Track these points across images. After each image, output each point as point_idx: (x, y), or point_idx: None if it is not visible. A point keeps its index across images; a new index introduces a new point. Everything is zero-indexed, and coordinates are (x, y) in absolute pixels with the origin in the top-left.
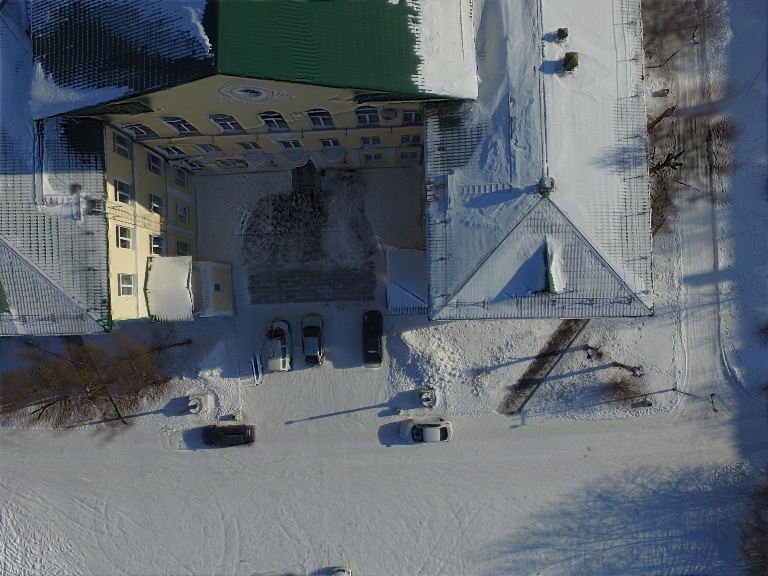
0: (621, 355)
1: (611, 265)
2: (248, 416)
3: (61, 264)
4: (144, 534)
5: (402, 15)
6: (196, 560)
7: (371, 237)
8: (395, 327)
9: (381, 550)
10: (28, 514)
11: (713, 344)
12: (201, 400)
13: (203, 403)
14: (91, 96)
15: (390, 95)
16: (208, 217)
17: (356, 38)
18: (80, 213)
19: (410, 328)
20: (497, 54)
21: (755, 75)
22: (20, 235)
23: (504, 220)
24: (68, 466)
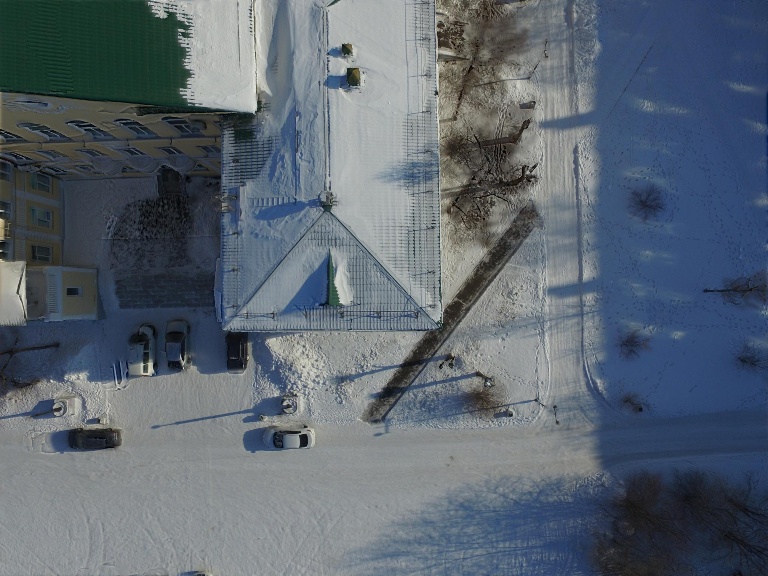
0: (484, 365)
1: (396, 279)
2: (115, 420)
3: None
4: (10, 536)
5: (171, 29)
6: (61, 562)
7: None
8: (261, 334)
9: (243, 555)
10: None
11: (576, 355)
12: (66, 403)
13: (68, 406)
14: None
15: (163, 108)
16: (75, 221)
17: (116, 52)
18: None
19: (275, 335)
20: (285, 68)
21: (623, 88)
22: None
23: (290, 233)
24: None
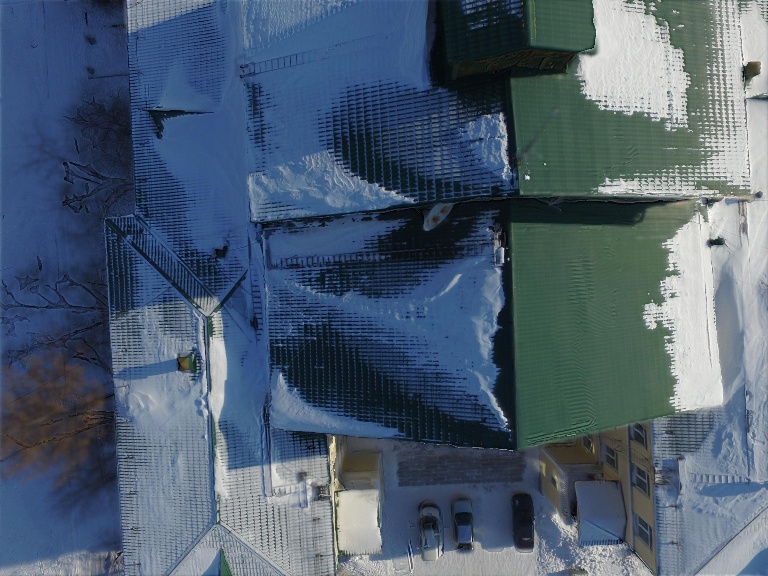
0: None
1: None
2: None
3: (290, 553)
4: None
5: (659, 338)
6: None
7: None
8: (544, 508)
9: None
10: None
11: None
12: None
13: None
14: (350, 427)
15: None
16: None
17: (624, 375)
18: (307, 500)
19: None
20: (731, 346)
21: None
22: (251, 528)
23: (741, 512)
24: None
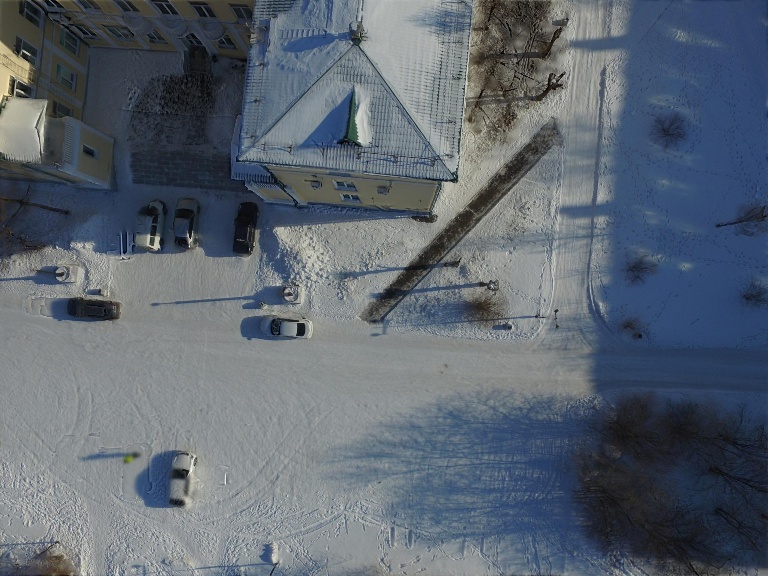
0: (489, 276)
1: (417, 123)
2: (116, 293)
3: None
4: None
5: None
6: (47, 428)
7: None
8: (269, 221)
9: (228, 440)
10: None
11: (582, 277)
12: (69, 269)
13: (71, 272)
14: None
15: None
16: (98, 89)
17: None
18: None
19: (284, 224)
20: None
21: (657, 16)
22: None
23: (316, 65)
24: None
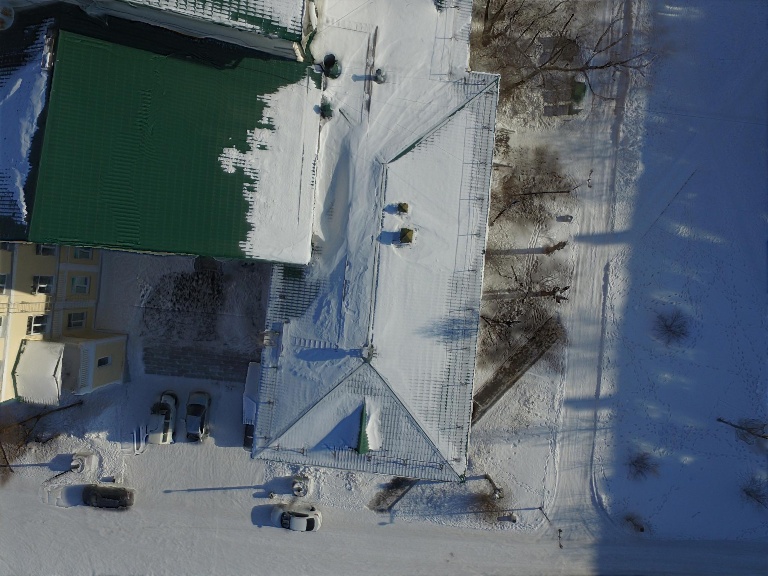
0: (494, 468)
1: (426, 432)
2: (129, 480)
3: None
4: None
5: (237, 183)
6: None
7: None
8: None
9: None
10: None
11: (585, 469)
12: (84, 461)
13: (85, 464)
14: None
15: None
16: (111, 286)
17: (183, 206)
18: None
19: None
20: (341, 217)
21: (660, 212)
22: None
23: (328, 377)
24: None
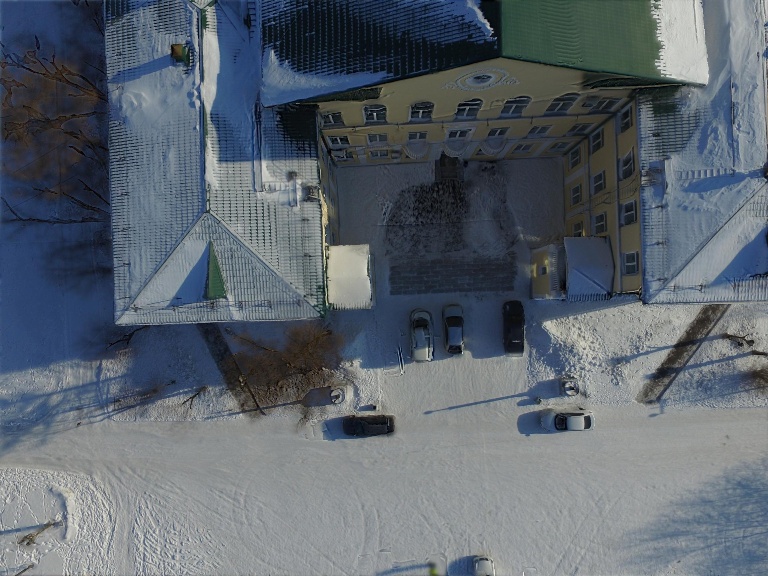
0: (760, 344)
1: None
2: (387, 406)
3: (279, 250)
4: (284, 524)
5: (646, 1)
6: (336, 550)
7: (513, 227)
8: (535, 317)
9: (522, 539)
10: (167, 505)
11: None
12: (343, 390)
13: (345, 393)
14: (340, 82)
15: (629, 80)
16: (350, 208)
17: (610, 23)
18: (296, 200)
19: (550, 318)
20: (718, 40)
21: None
22: (241, 221)
23: (726, 204)
24: (206, 457)
